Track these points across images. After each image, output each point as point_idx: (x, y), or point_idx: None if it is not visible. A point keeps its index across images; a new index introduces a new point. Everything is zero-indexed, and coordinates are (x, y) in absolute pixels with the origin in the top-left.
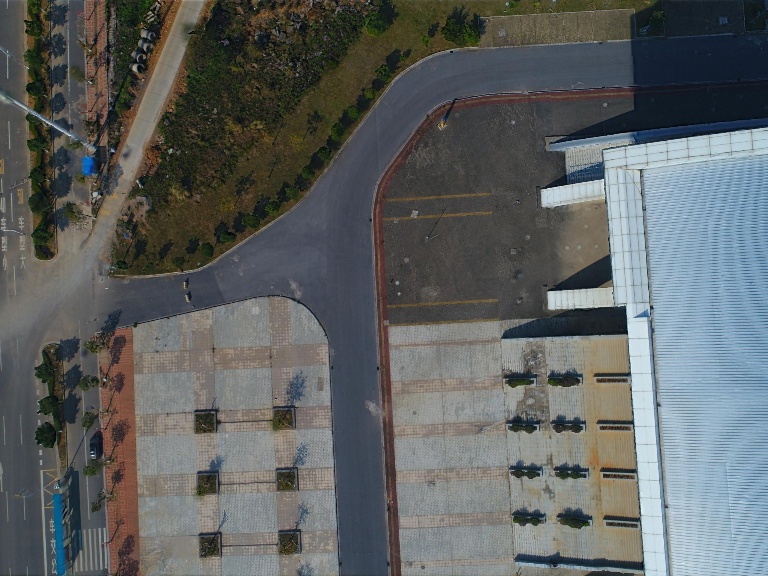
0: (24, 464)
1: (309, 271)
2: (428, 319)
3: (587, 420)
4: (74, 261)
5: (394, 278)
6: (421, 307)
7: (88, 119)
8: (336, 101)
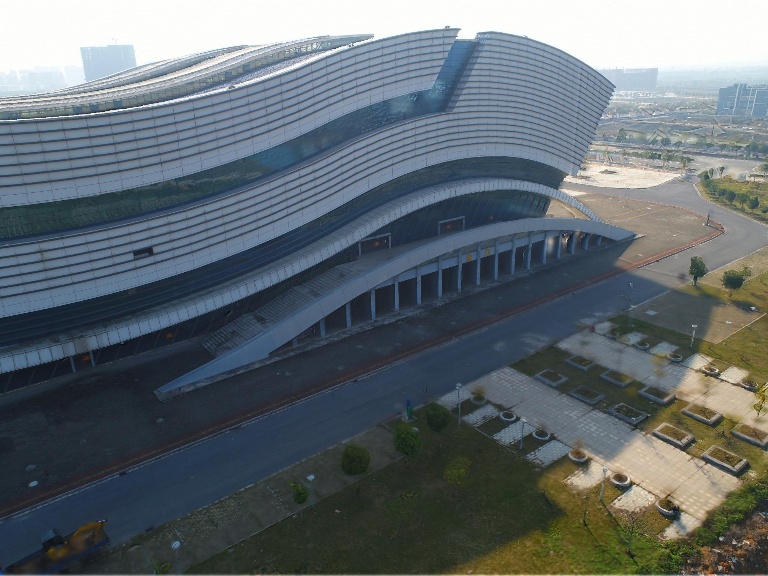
0: (644, 162)
1: None
2: None
3: None
4: None
5: None
6: None
7: None
8: None
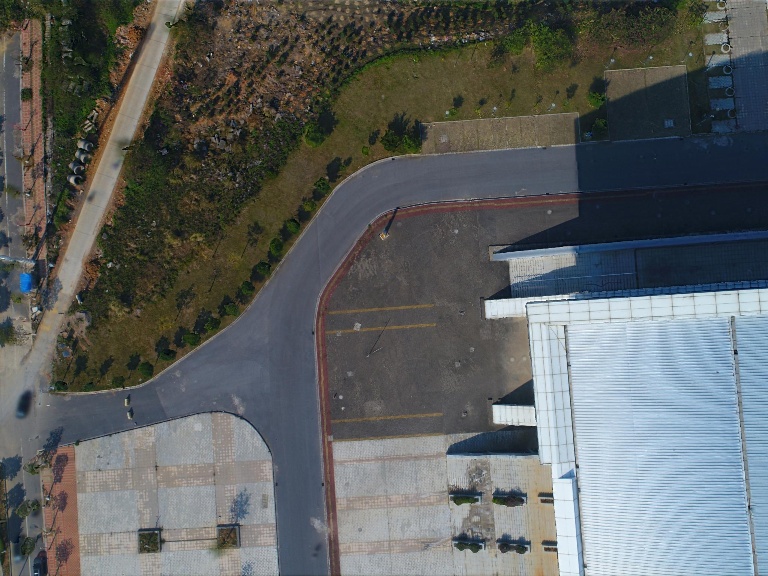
0: None
1: (252, 386)
2: (372, 434)
3: (532, 540)
4: (15, 378)
5: (338, 392)
6: (365, 422)
7: (26, 232)
8: (276, 212)
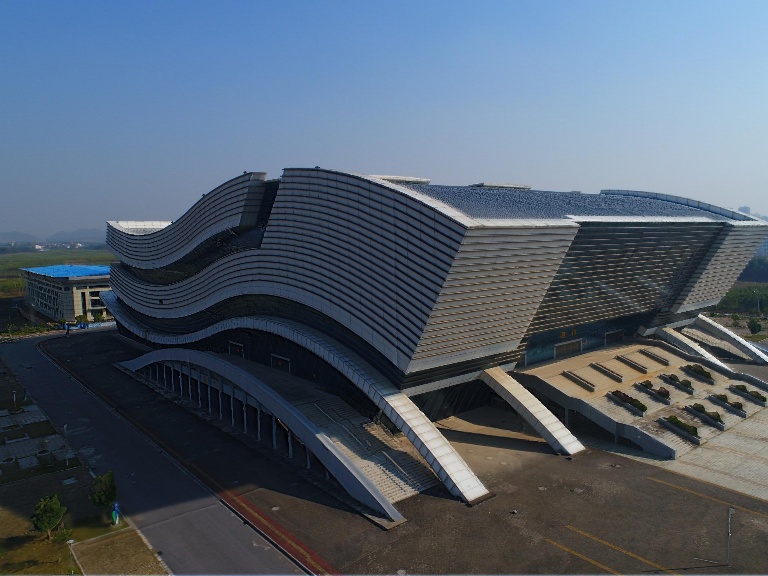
0: None
1: None
2: None
3: (629, 386)
4: None
5: None
6: None
7: None
8: None
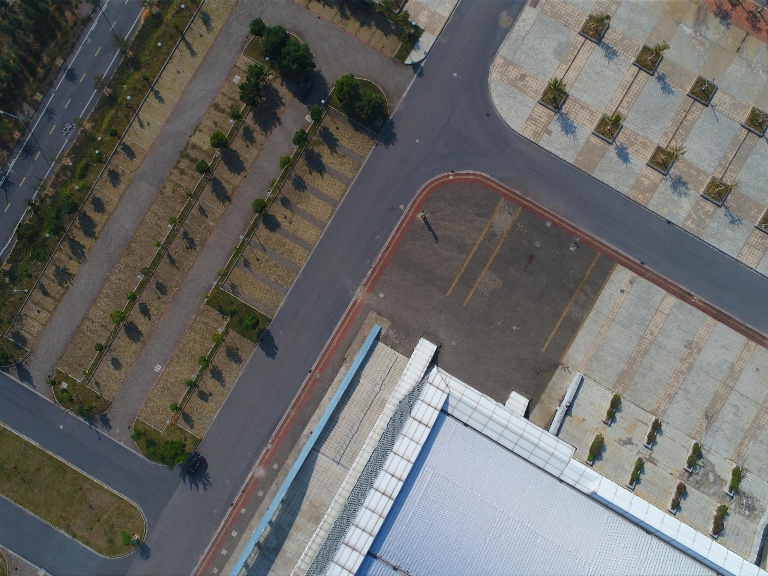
0: None
1: None
2: None
3: None
4: None
5: None
6: None
7: None
8: None
